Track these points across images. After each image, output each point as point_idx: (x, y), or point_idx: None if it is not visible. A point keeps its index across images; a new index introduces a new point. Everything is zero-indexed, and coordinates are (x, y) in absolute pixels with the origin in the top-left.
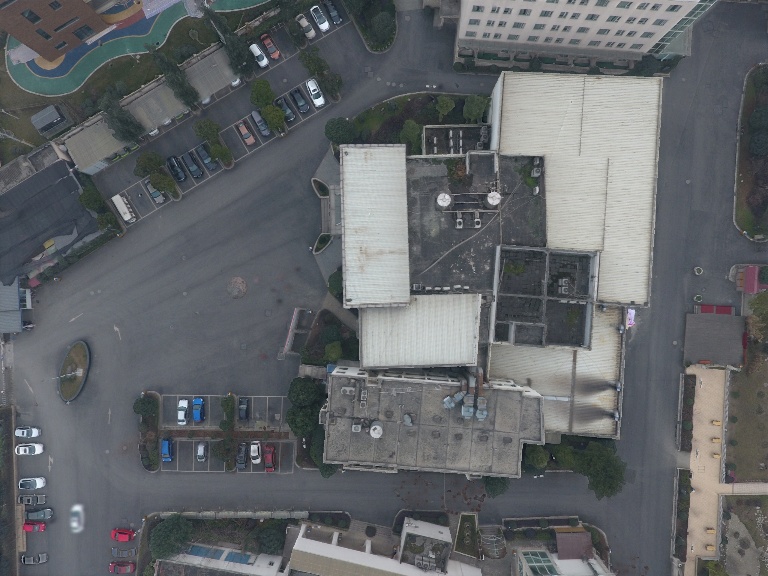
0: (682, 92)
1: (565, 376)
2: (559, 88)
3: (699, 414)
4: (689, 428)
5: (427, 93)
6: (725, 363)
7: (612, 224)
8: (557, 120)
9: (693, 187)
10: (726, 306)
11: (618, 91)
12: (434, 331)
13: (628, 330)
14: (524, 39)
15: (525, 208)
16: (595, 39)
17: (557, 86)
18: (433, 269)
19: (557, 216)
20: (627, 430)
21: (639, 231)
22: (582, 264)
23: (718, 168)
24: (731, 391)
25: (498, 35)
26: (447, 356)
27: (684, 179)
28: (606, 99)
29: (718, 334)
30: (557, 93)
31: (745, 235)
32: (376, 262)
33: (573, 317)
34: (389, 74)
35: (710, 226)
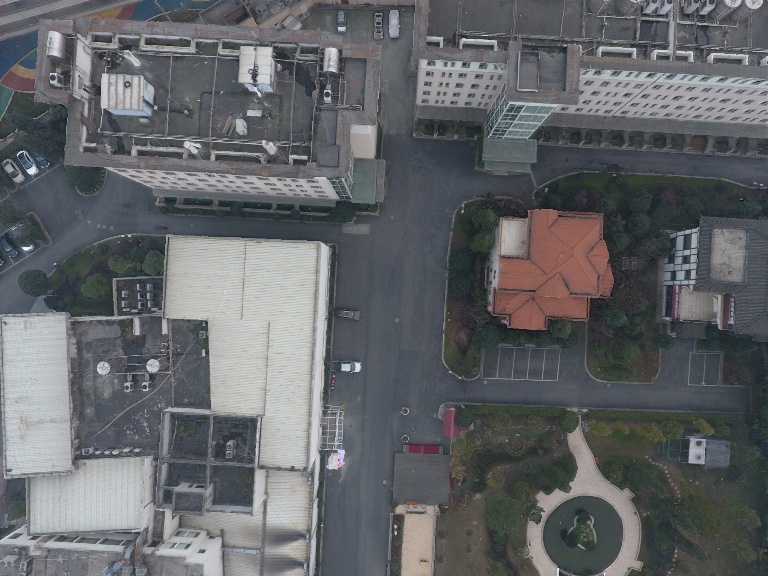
0: (391, 230)
1: (256, 527)
2: (221, 252)
3: (409, 553)
4: (394, 570)
5: (136, 235)
6: (433, 502)
7: (273, 389)
8: (220, 284)
9: (402, 326)
10: (434, 445)
11: (278, 255)
12: (102, 496)
13: (338, 470)
14: (212, 190)
15: (198, 368)
16: (277, 192)
17: (219, 250)
18: (107, 431)
19: (220, 380)
20: (338, 570)
21: (299, 396)
22: (254, 424)
23: (427, 306)
24: (439, 530)
25: (184, 187)
26: (114, 521)
27: (393, 318)
28: (266, 263)
29: (426, 474)
30: (220, 257)
31: (453, 373)
32: (37, 431)
33: (244, 478)
34: (100, 216)
35: (419, 365)
